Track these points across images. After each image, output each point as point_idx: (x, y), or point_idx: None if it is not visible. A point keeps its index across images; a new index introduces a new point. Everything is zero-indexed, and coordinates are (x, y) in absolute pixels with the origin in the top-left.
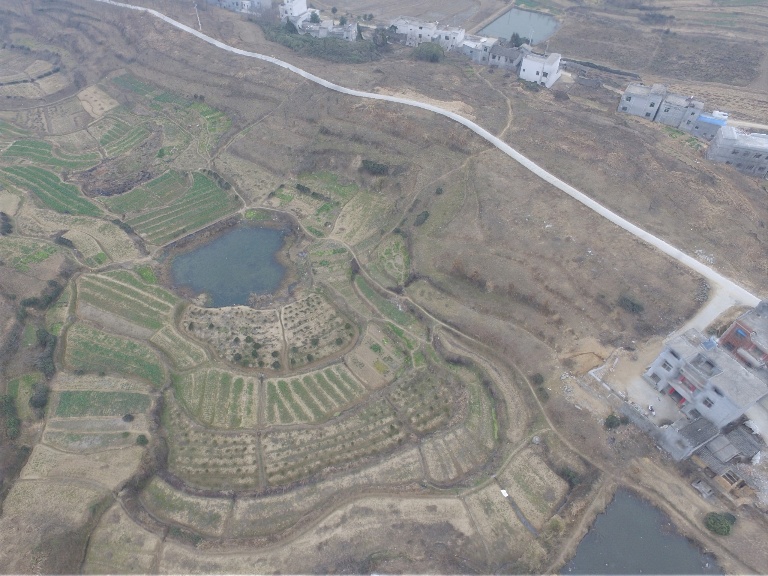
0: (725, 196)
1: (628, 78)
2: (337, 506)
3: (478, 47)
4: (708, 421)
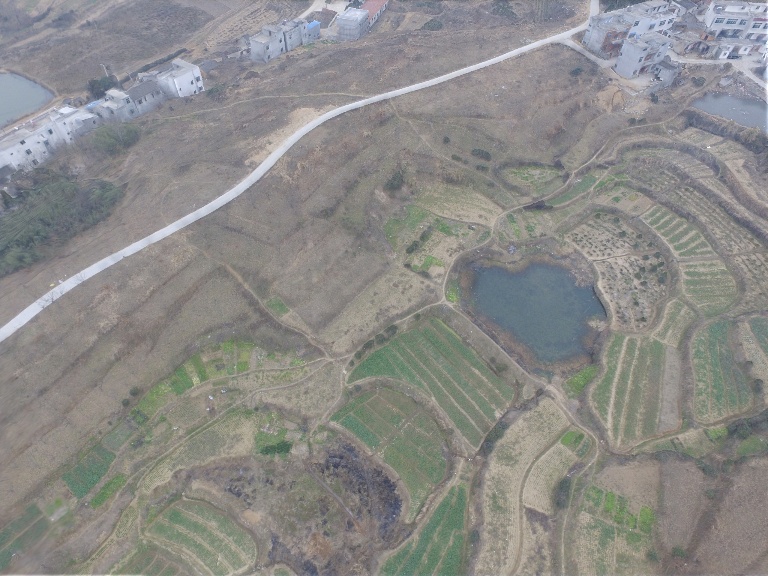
0: None
1: (185, 54)
2: (765, 206)
3: (118, 105)
4: (662, 62)
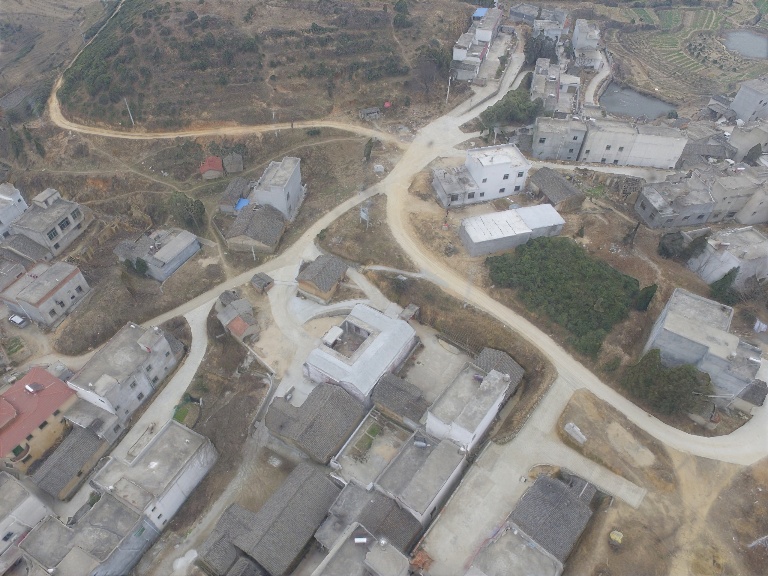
0: None
1: None
2: (628, 56)
3: None
4: None
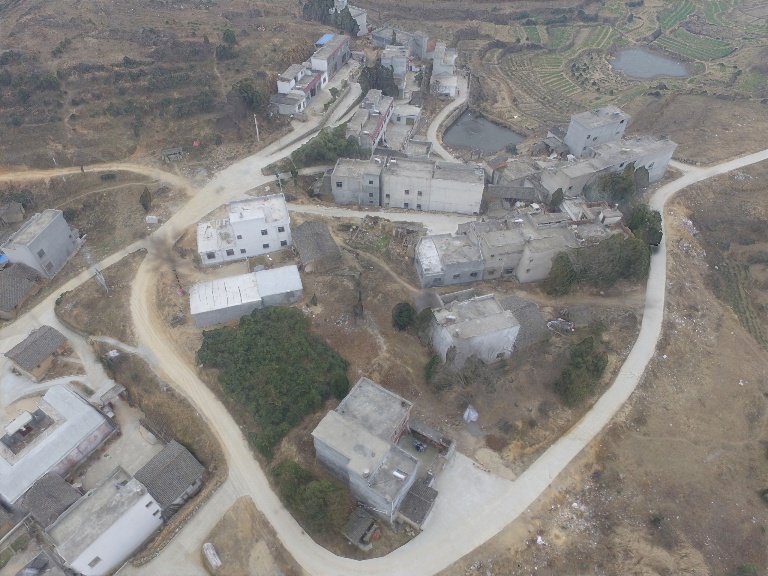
0: None
1: None
2: (499, 79)
3: None
4: None
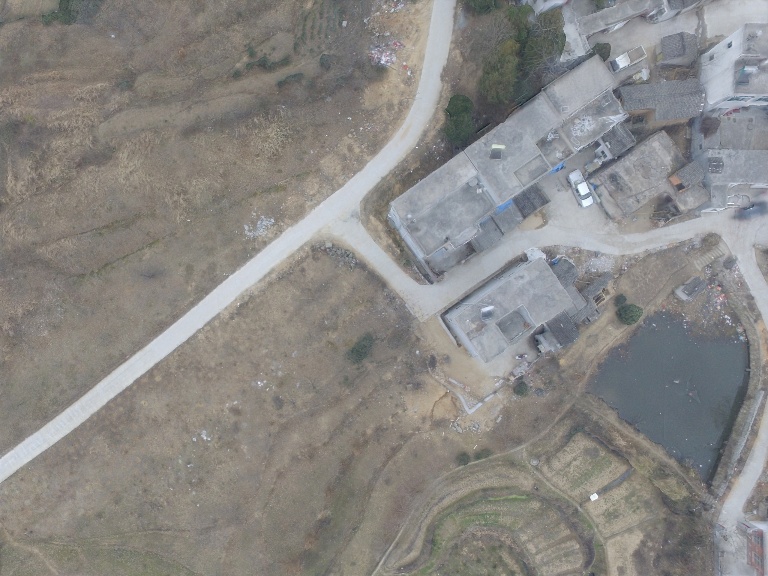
0: (69, 123)
1: None
2: None
3: None
4: None
